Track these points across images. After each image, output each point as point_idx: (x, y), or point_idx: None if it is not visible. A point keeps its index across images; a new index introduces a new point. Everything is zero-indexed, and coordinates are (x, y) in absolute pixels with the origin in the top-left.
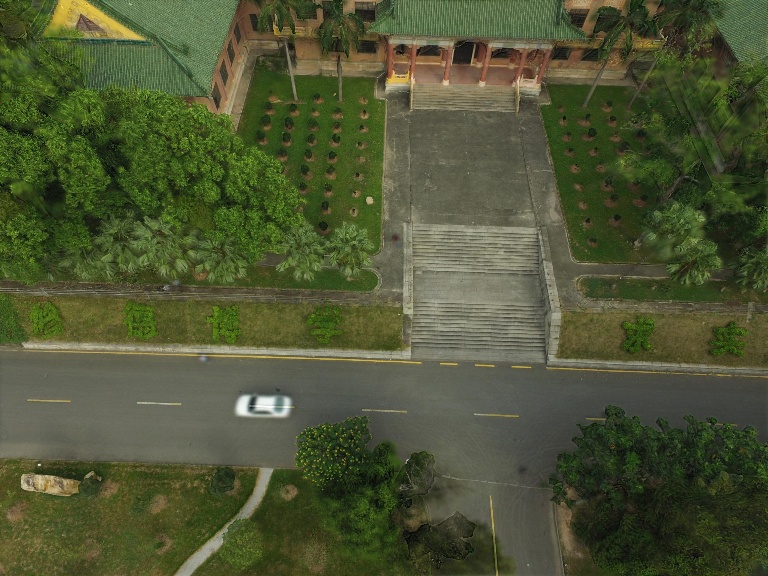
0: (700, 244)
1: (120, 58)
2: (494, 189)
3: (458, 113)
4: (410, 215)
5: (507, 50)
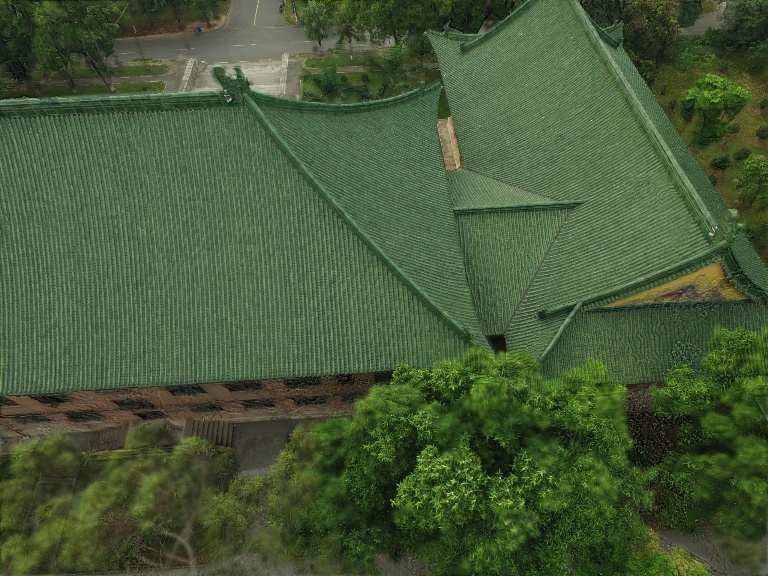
0: (95, 11)
1: None
2: None
3: None
4: None
5: None
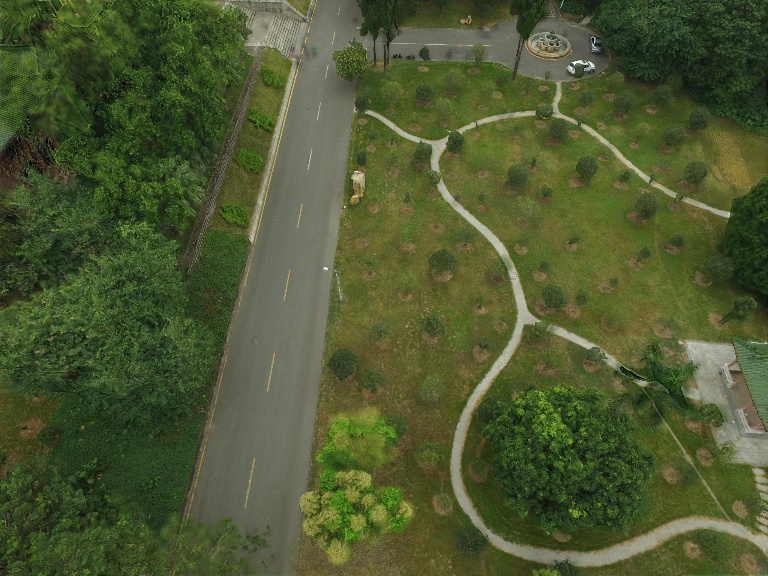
0: None
1: (5, 80)
2: None
3: None
4: None
5: None
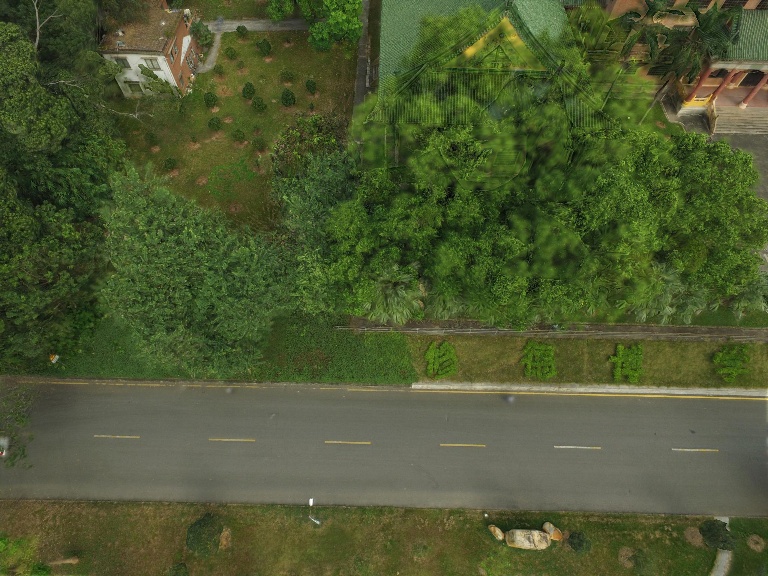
0: None
1: None
2: None
3: (760, 137)
4: (765, 246)
5: None
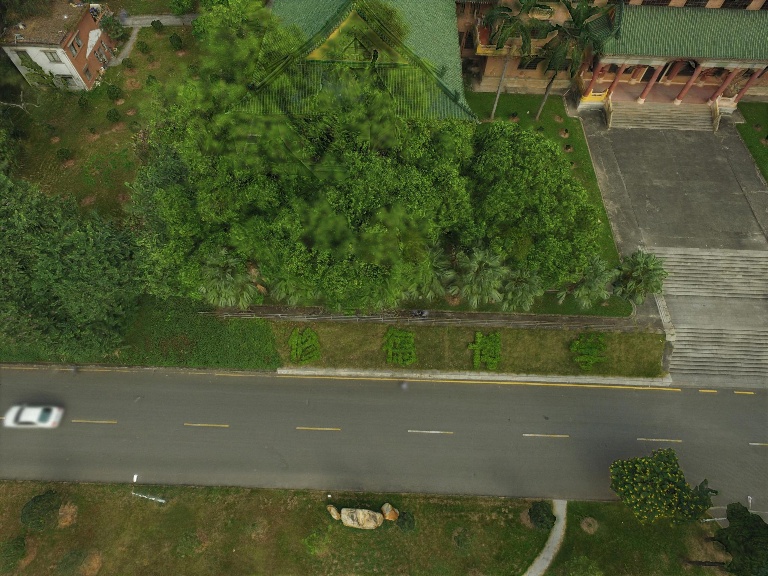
0: None
1: None
2: (717, 211)
3: (656, 132)
4: (641, 238)
5: (717, 69)
